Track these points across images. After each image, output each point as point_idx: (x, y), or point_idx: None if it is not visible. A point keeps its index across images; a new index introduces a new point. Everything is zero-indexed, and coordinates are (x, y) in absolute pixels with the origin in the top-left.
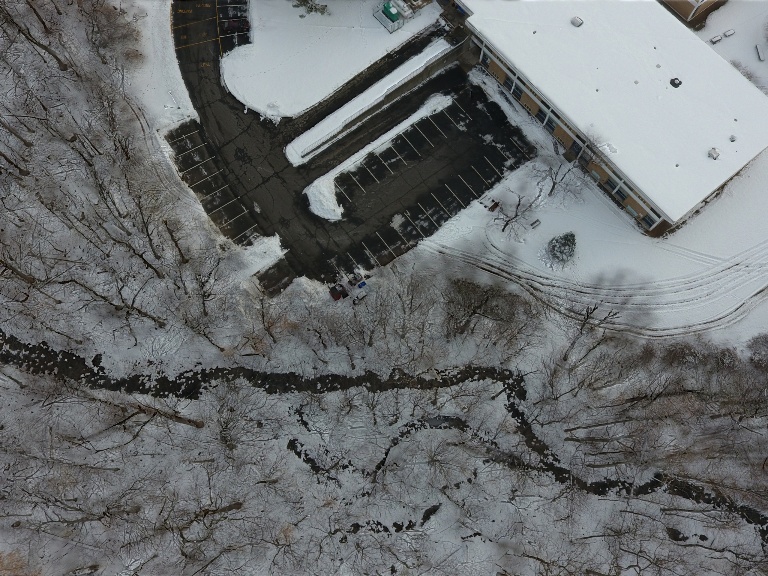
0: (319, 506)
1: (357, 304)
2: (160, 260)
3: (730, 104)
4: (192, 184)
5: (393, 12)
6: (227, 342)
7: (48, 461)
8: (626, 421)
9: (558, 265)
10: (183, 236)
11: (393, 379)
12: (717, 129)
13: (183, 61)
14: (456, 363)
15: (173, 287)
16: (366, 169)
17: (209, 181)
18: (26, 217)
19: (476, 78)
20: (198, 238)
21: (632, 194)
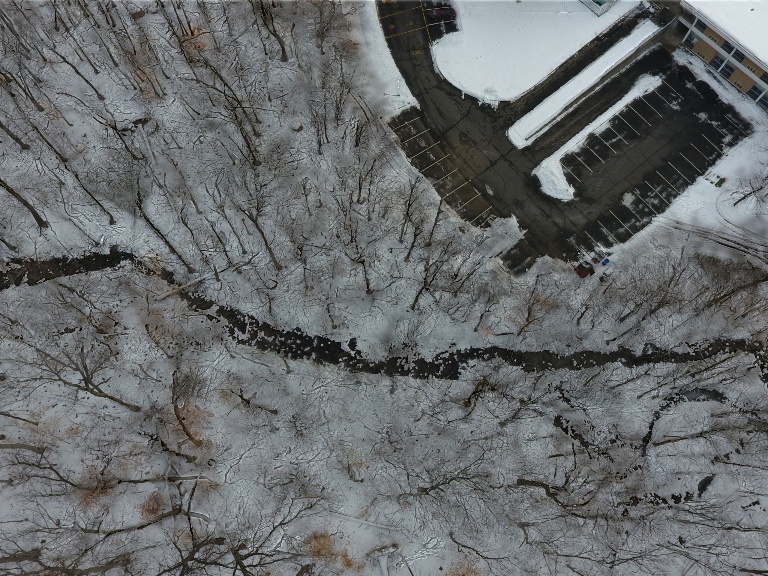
0: (601, 480)
1: (604, 281)
2: (403, 244)
3: None
4: (422, 169)
5: None
6: None
7: (328, 444)
8: None
9: None
10: (444, 217)
11: (647, 354)
12: None
13: (395, 50)
14: (706, 336)
15: (419, 270)
16: (589, 149)
17: (438, 166)
18: None
19: (681, 58)
20: None
21: None
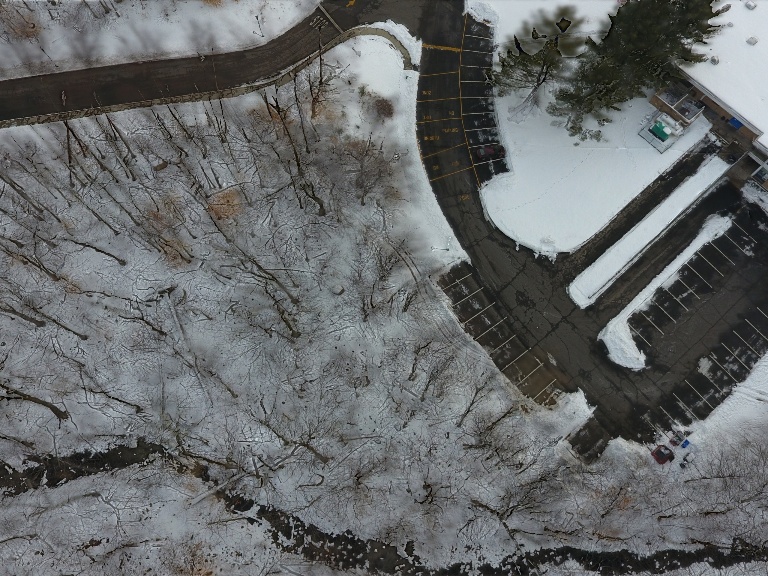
0: None
1: None
2: (461, 428)
3: None
4: (477, 336)
5: (668, 132)
6: None
7: None
8: None
9: None
10: None
11: (736, 551)
12: None
13: (440, 195)
14: None
15: (480, 458)
16: (658, 307)
17: (494, 331)
18: (307, 386)
19: (751, 195)
20: (497, 399)
21: None
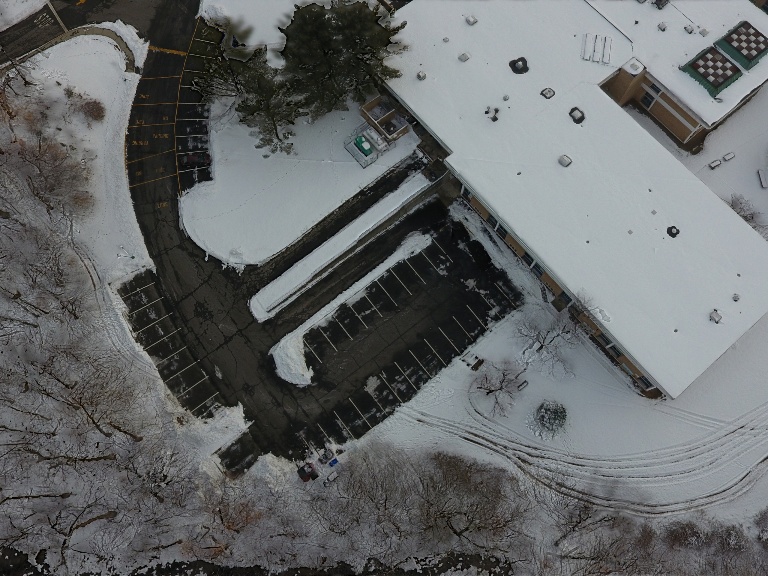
0: None
1: (328, 486)
2: (111, 438)
3: (732, 256)
4: (147, 346)
5: (366, 147)
6: (185, 532)
7: None
8: None
9: (548, 433)
10: (133, 426)
11: (368, 571)
12: (719, 286)
13: (138, 201)
14: (437, 550)
15: (125, 469)
16: (338, 323)
17: (166, 342)
18: None
19: (457, 213)
20: (153, 411)
21: None
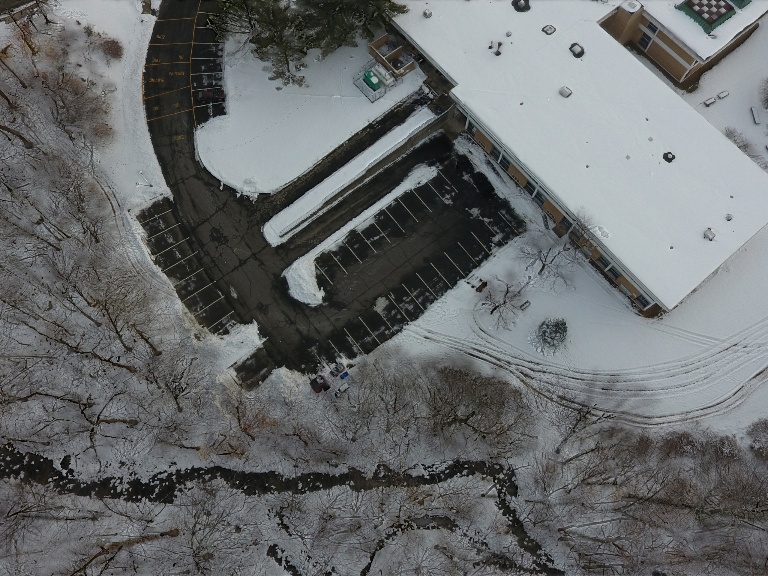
0: None
1: (339, 397)
2: (132, 352)
3: (726, 180)
4: (165, 268)
5: (374, 82)
6: (203, 440)
7: None
8: (622, 519)
9: (549, 349)
10: (154, 334)
11: (378, 476)
12: (712, 207)
13: (155, 134)
14: (444, 457)
15: (146, 381)
16: (348, 248)
17: (183, 264)
18: None
19: (462, 147)
20: (172, 327)
21: (625, 275)
